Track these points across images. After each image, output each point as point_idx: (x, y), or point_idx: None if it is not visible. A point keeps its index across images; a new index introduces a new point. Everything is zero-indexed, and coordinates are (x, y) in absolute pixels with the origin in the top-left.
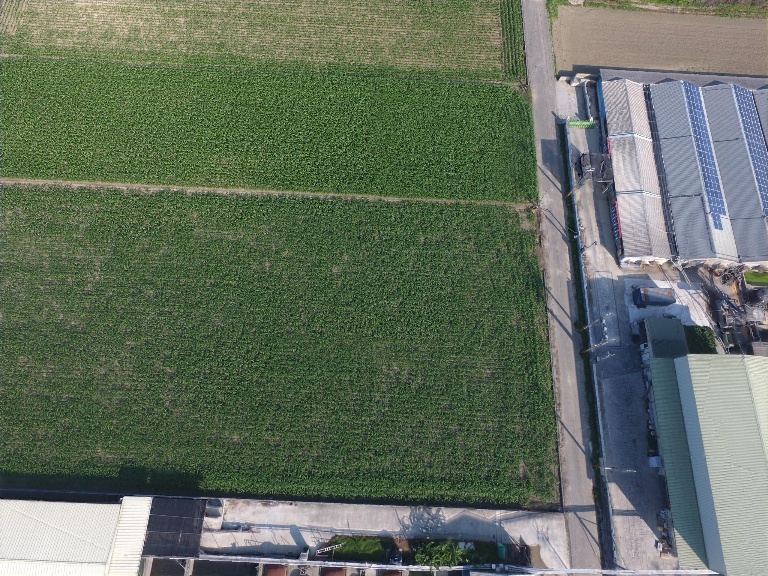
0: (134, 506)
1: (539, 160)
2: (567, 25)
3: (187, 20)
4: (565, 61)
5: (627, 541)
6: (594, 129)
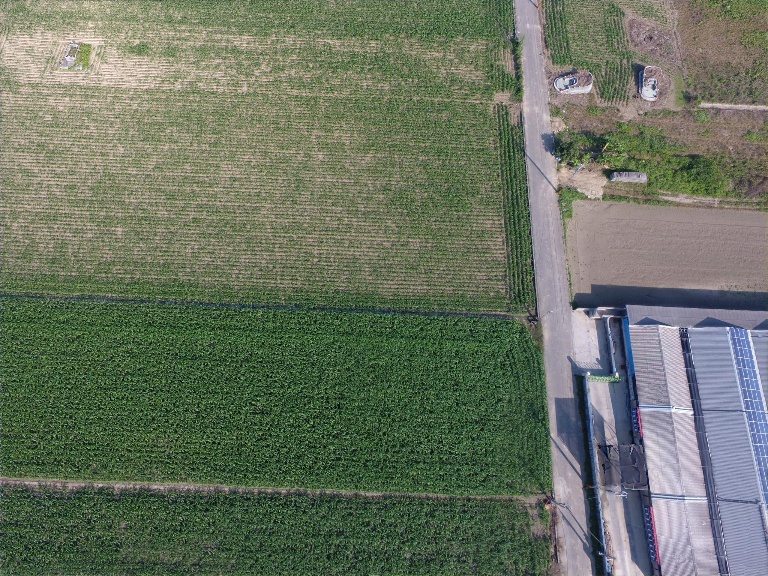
0: None
1: (553, 429)
2: (583, 228)
3: (126, 230)
4: (582, 279)
5: None
6: (620, 383)
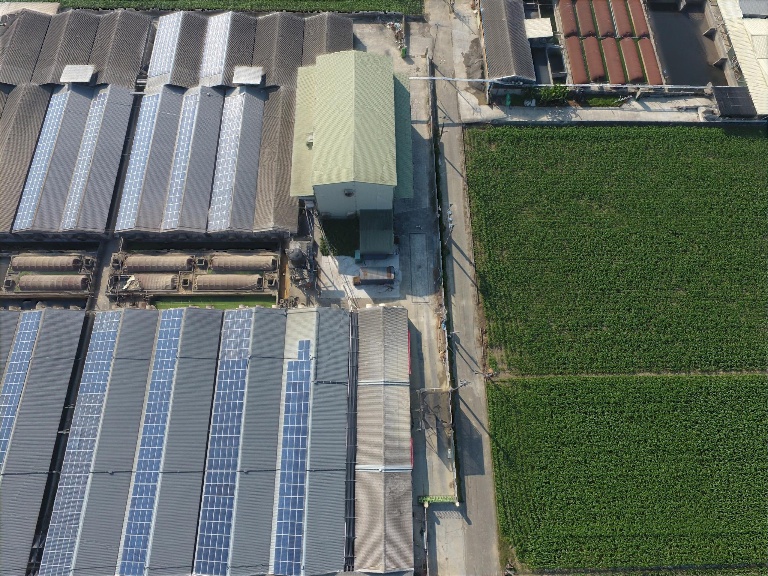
0: (767, 109)
1: (486, 441)
2: None
3: None
4: None
5: (419, 107)
6: (417, 496)
